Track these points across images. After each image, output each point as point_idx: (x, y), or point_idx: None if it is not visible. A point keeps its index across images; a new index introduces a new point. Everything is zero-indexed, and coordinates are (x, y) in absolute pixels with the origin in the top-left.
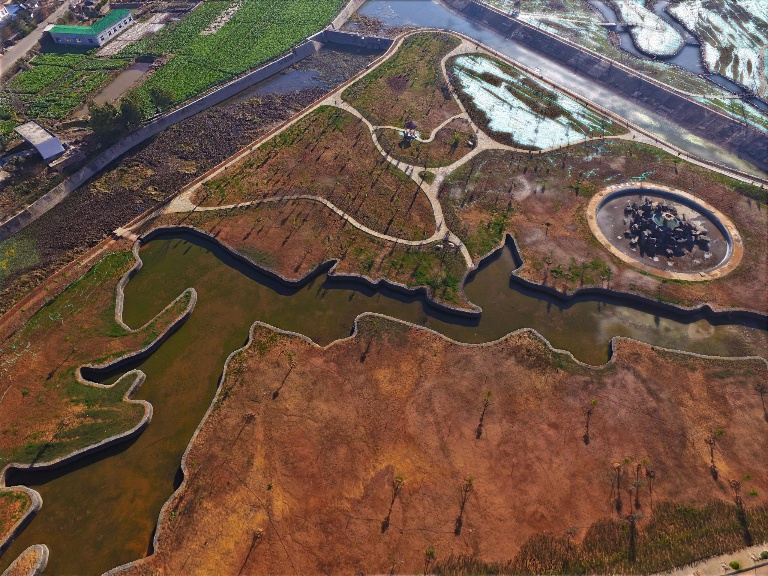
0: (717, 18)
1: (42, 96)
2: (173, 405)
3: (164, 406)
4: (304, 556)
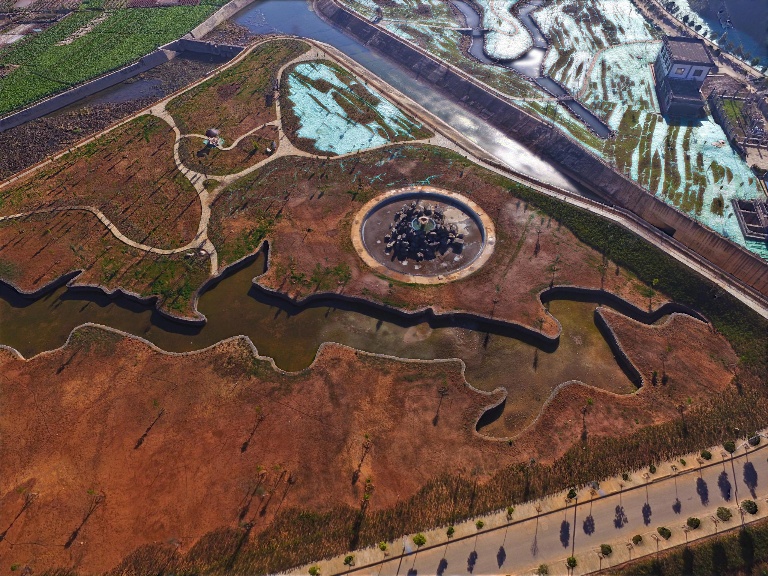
0: (571, 22)
1: None
2: None
3: None
4: None
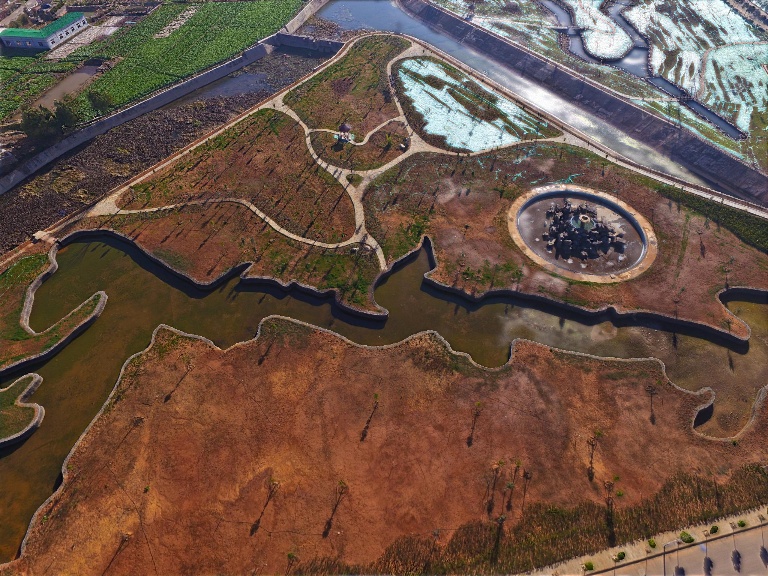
0: (668, 21)
1: None
2: (66, 408)
3: (56, 409)
4: (168, 559)
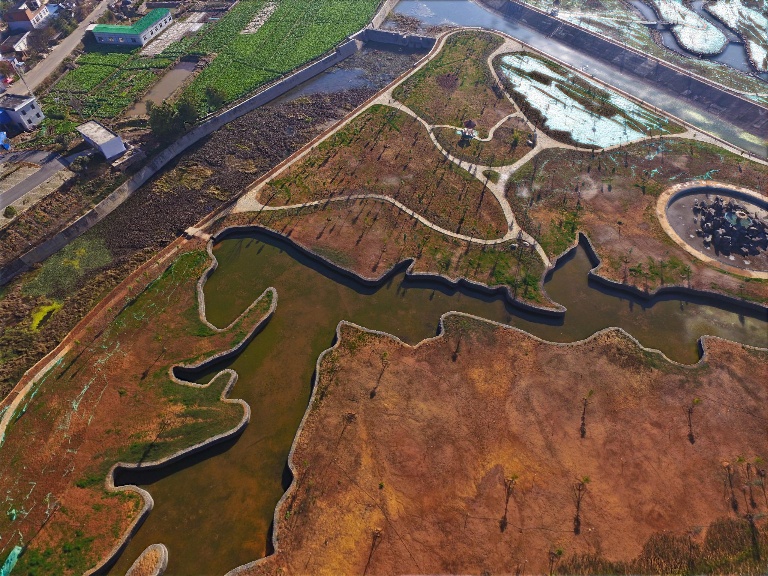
0: (758, 16)
1: (92, 96)
2: (269, 404)
3: (261, 405)
4: (427, 555)
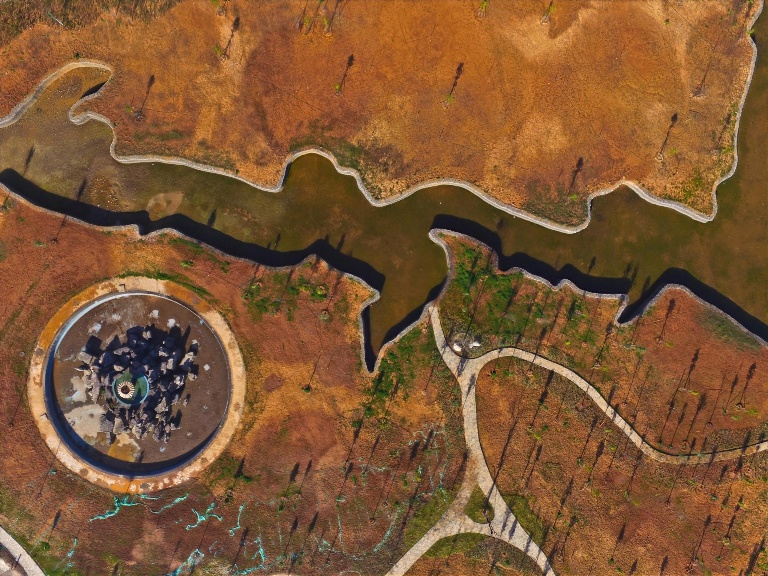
0: None
1: None
2: None
3: None
4: None
